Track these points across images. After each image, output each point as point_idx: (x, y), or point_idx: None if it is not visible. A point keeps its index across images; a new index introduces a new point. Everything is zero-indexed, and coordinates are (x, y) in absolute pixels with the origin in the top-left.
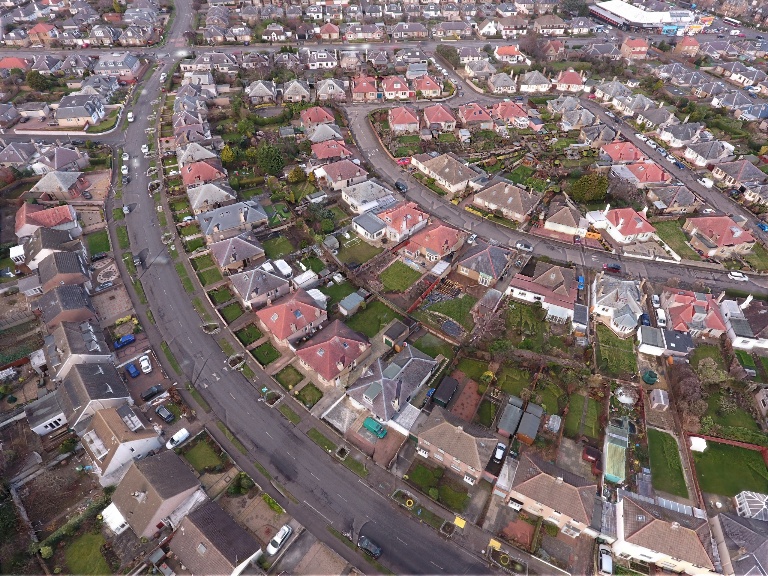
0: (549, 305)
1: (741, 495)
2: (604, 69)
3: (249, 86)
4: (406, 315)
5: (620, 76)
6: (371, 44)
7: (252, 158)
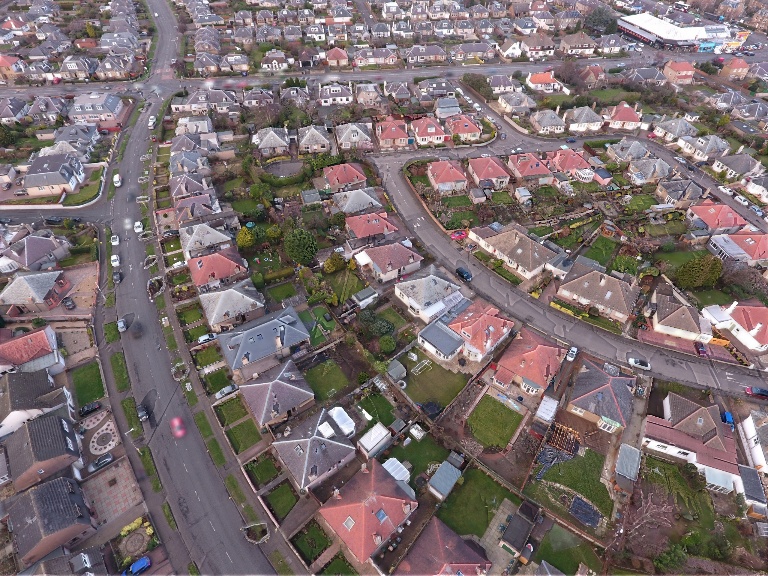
0: (704, 467)
1: None
2: (654, 99)
3: (257, 134)
4: (521, 495)
5: (673, 107)
6: (385, 71)
7: (275, 239)
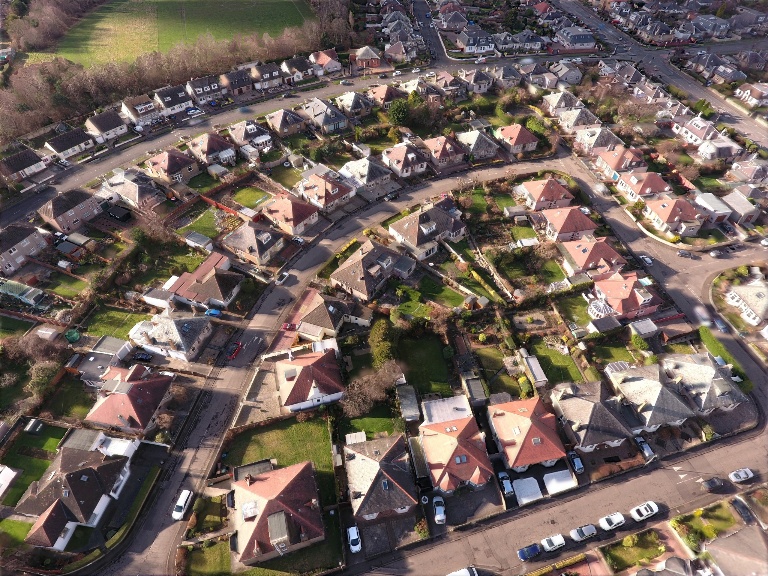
0: None
1: None
2: None
3: None
4: (200, 197)
5: None
6: None
7: None
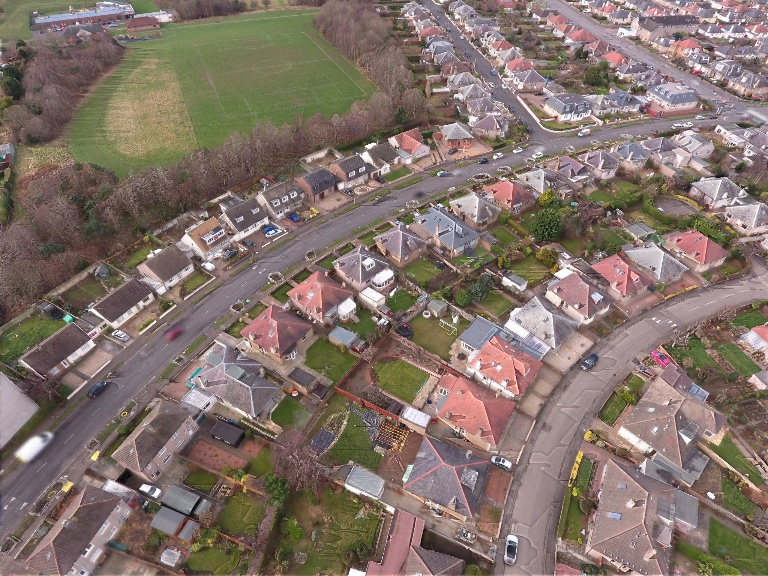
0: (366, 571)
1: None
2: None
3: None
4: None
5: None
6: None
7: None
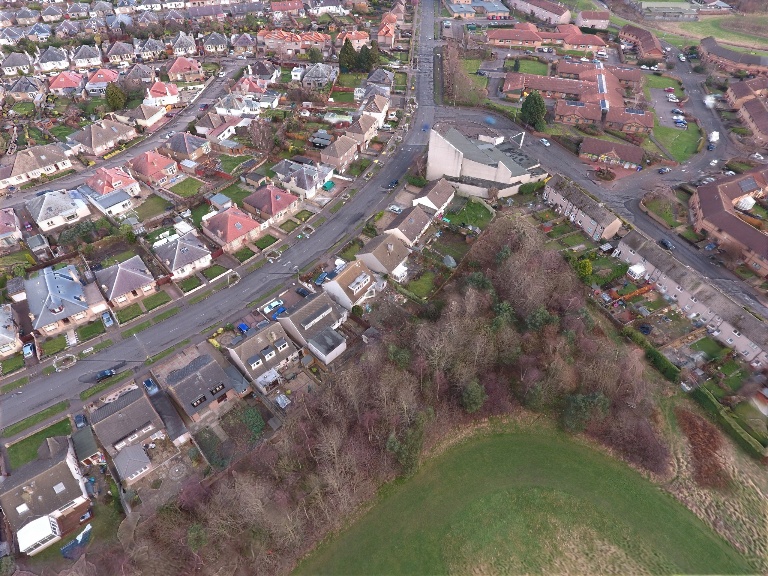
0: None
1: (355, 94)
2: None
3: None
4: None
5: None
6: None
7: None
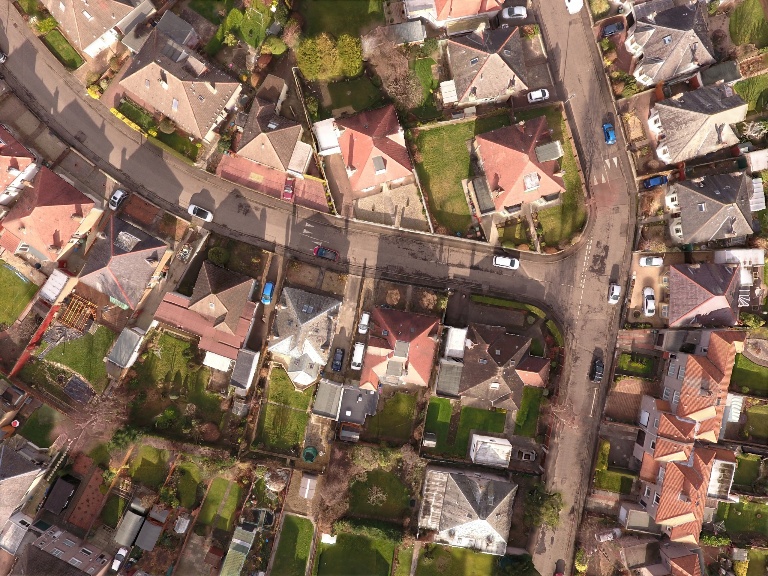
0: (206, 350)
1: None
2: None
3: None
4: None
5: None
6: None
7: None
